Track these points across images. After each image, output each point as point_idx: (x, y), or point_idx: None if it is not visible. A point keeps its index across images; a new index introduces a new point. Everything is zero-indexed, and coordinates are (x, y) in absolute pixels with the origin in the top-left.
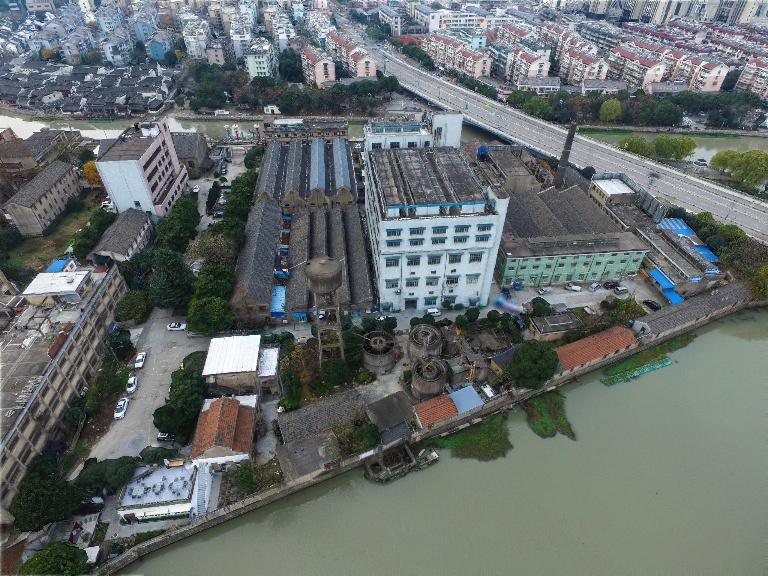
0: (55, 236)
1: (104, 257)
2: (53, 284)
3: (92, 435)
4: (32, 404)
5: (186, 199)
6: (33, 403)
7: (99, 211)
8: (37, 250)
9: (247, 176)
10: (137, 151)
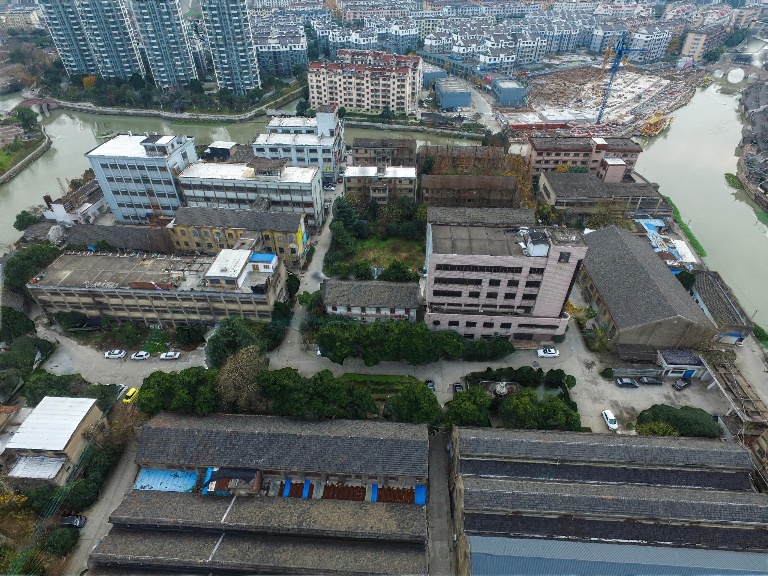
0: (422, 256)
1: (265, 283)
2: (226, 261)
3: (99, 342)
4: (97, 292)
5: (439, 334)
6: (98, 292)
7: (394, 263)
8: (397, 252)
9: (526, 406)
10: (468, 248)
